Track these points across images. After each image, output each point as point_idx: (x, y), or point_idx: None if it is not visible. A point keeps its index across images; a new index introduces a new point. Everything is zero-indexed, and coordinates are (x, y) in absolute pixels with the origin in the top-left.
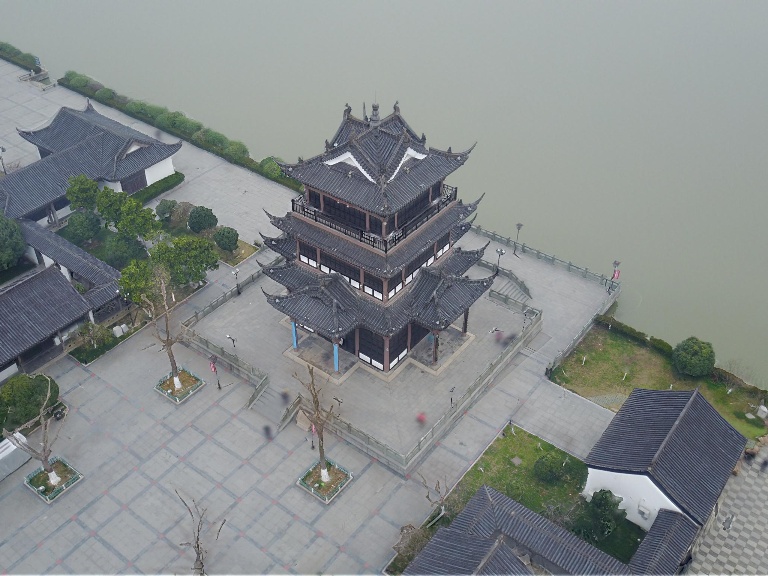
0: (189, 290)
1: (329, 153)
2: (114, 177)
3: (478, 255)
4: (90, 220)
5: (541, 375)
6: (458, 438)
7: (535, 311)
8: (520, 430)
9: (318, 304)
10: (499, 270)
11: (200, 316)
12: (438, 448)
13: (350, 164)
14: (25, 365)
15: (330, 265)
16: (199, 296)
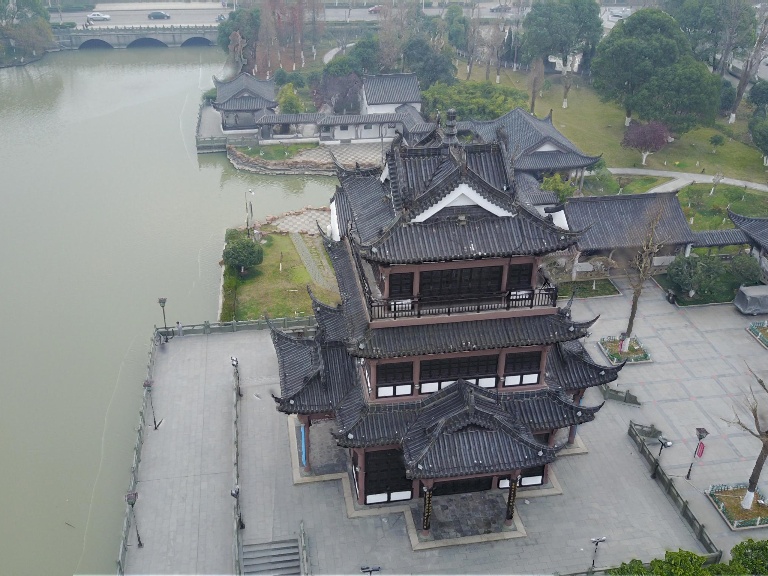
0: None
1: None
2: None
3: None
4: None
5: None
6: None
7: None
8: None
9: None
10: (238, 389)
11: None
12: None
13: None
14: None
15: None
16: None
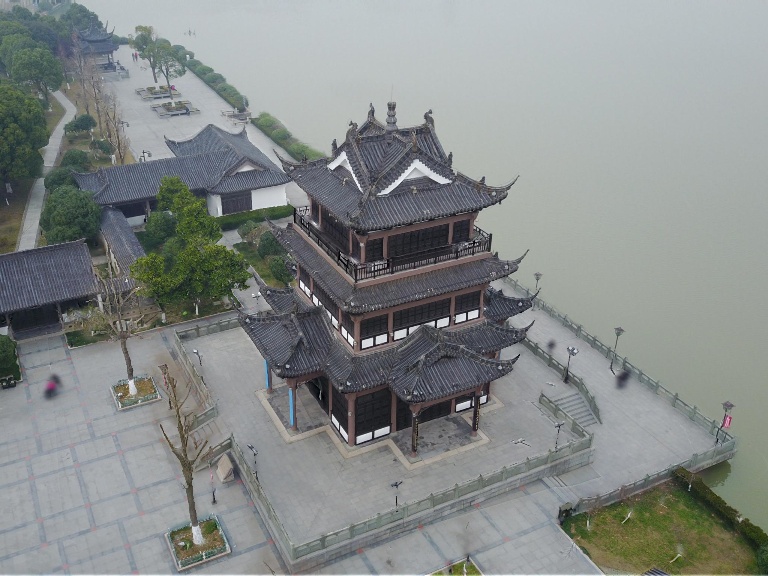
0: (219, 309)
1: (334, 155)
2: (212, 188)
3: (517, 336)
4: (166, 221)
5: (552, 516)
6: (389, 553)
7: (585, 434)
8: (476, 573)
9: (286, 335)
10: (569, 376)
11: (203, 332)
12: (356, 556)
13: (348, 169)
14: (21, 332)
15: (319, 295)
16: (225, 317)
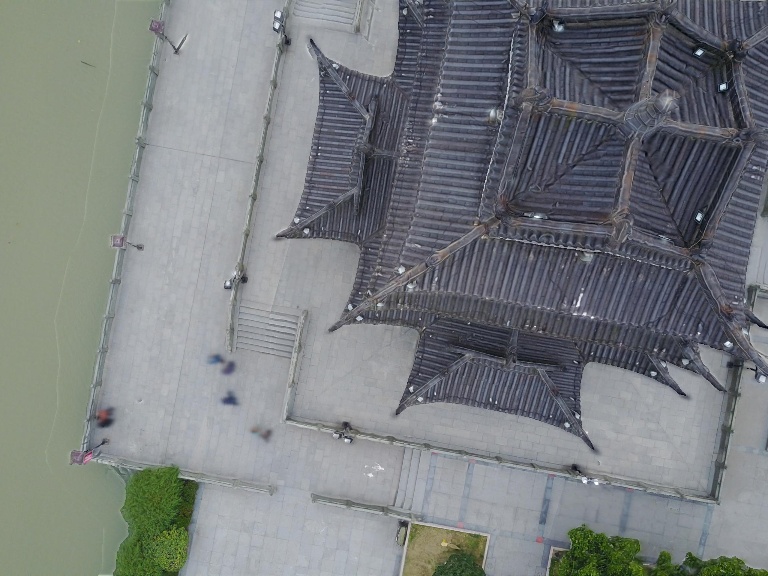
0: None
1: None
2: None
3: (413, 2)
4: None
5: None
6: None
7: None
8: None
9: None
10: None
11: None
12: None
13: None
14: None
15: None
16: None
